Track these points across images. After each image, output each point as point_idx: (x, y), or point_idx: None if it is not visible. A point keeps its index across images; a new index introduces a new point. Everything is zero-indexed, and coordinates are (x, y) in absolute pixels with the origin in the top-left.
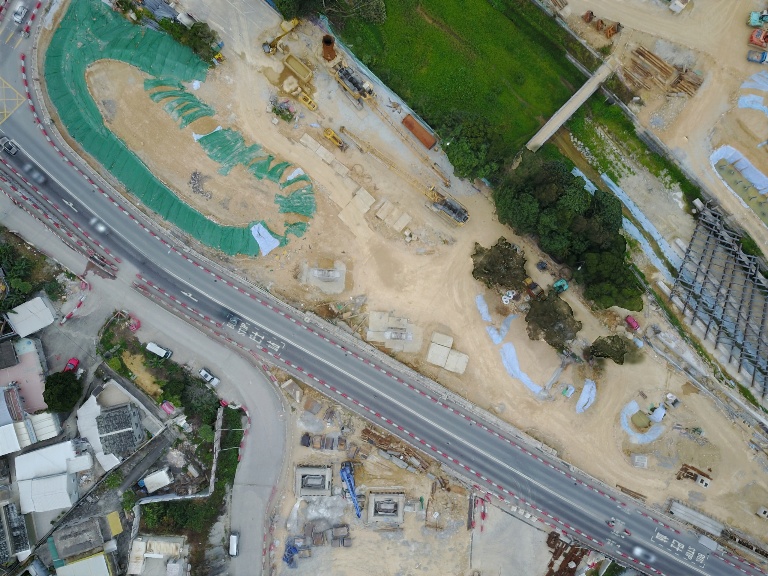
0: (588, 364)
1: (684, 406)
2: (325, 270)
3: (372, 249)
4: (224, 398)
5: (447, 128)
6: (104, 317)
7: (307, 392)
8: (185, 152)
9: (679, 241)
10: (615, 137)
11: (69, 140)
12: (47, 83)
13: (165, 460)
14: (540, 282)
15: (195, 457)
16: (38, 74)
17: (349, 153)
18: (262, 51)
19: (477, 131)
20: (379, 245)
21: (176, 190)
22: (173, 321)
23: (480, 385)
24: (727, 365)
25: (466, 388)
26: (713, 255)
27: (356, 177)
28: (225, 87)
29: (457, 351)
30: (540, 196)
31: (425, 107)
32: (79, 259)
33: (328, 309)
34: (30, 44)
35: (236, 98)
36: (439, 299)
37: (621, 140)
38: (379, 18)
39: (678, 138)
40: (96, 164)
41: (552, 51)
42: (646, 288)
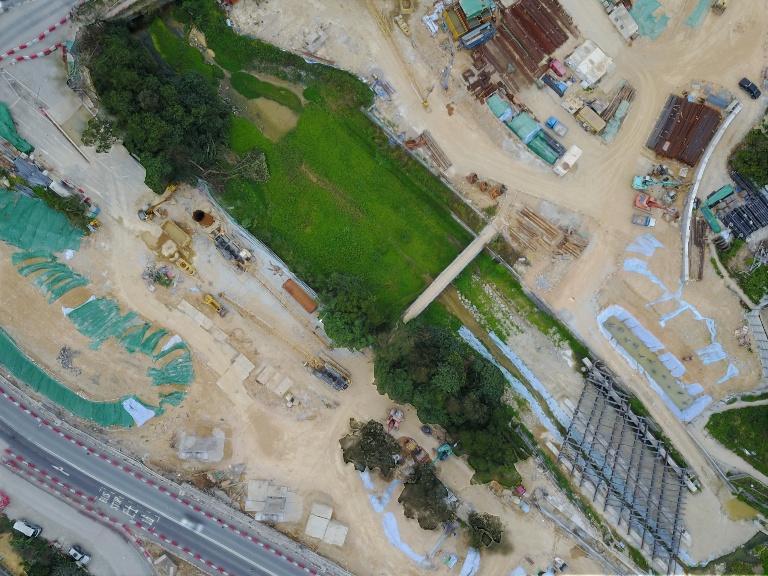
0: (474, 529)
1: (572, 571)
2: (193, 452)
3: (251, 417)
4: (96, 575)
5: (327, 294)
6: None
7: (182, 567)
8: (54, 327)
9: (567, 401)
10: (503, 294)
11: None
12: None
13: None
14: (425, 445)
15: None
16: None
17: (229, 317)
18: None
19: (350, 307)
20: (258, 412)
21: (44, 366)
22: (43, 496)
23: (361, 555)
24: (617, 526)
25: (347, 558)
26: (601, 416)
27: (235, 343)
28: (100, 254)
29: (337, 522)
30: (412, 376)
31: (305, 272)
32: None
33: (206, 478)
34: None
35: (112, 265)
36: (320, 466)
37: (509, 298)
38: (261, 178)
39: (564, 299)
40: None
41: (438, 210)
42: (534, 450)
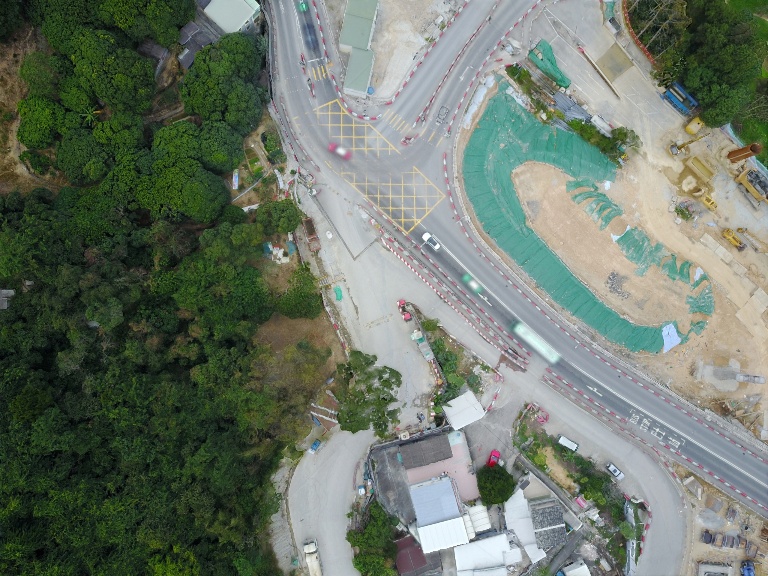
0: None
1: None
2: (751, 376)
3: None
4: (626, 492)
5: None
6: (516, 409)
7: (706, 489)
8: (604, 253)
9: None
10: None
11: (483, 236)
12: (464, 181)
13: (578, 553)
14: None
15: (606, 551)
16: (457, 172)
17: (744, 252)
18: (664, 151)
19: None
20: None
21: (595, 290)
22: (579, 415)
23: None
24: None
25: None
26: None
27: (753, 277)
28: (631, 187)
29: None
30: None
31: None
32: (493, 352)
33: (722, 406)
34: (450, 143)
35: (639, 197)
36: None
37: None
38: None
39: None
40: (508, 259)
41: None
42: None
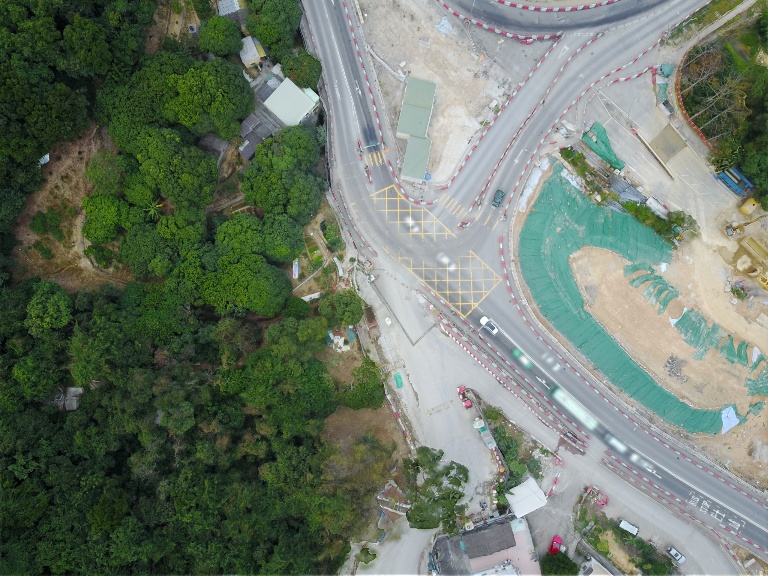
0: None
1: None
2: None
3: None
4: (686, 574)
5: None
6: (576, 493)
7: (767, 571)
8: (663, 337)
9: None
10: None
11: (540, 318)
12: (521, 263)
13: None
14: None
15: None
16: (513, 255)
17: None
18: (718, 231)
19: None
20: None
21: (654, 374)
22: (638, 497)
23: None
24: None
25: None
26: None
27: None
28: (687, 268)
29: None
30: None
31: None
32: (552, 435)
33: None
34: (506, 226)
35: (695, 278)
36: None
37: None
38: None
39: None
40: (565, 342)
41: None
42: None
